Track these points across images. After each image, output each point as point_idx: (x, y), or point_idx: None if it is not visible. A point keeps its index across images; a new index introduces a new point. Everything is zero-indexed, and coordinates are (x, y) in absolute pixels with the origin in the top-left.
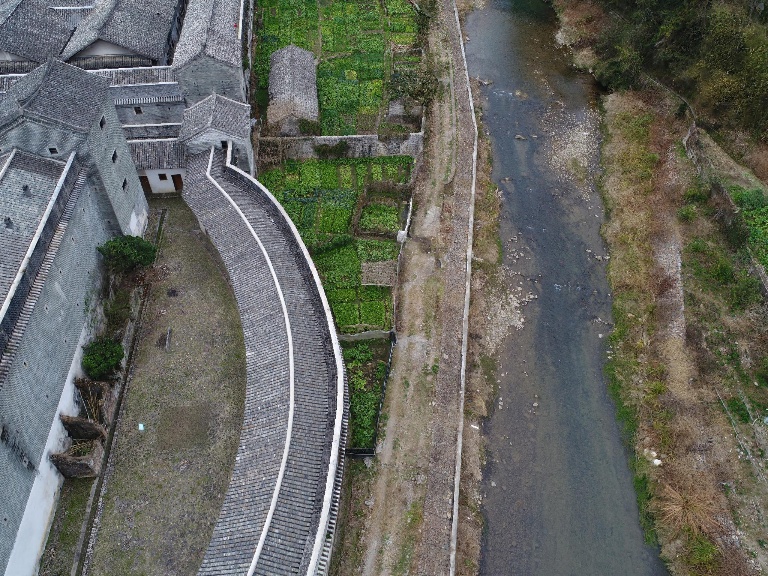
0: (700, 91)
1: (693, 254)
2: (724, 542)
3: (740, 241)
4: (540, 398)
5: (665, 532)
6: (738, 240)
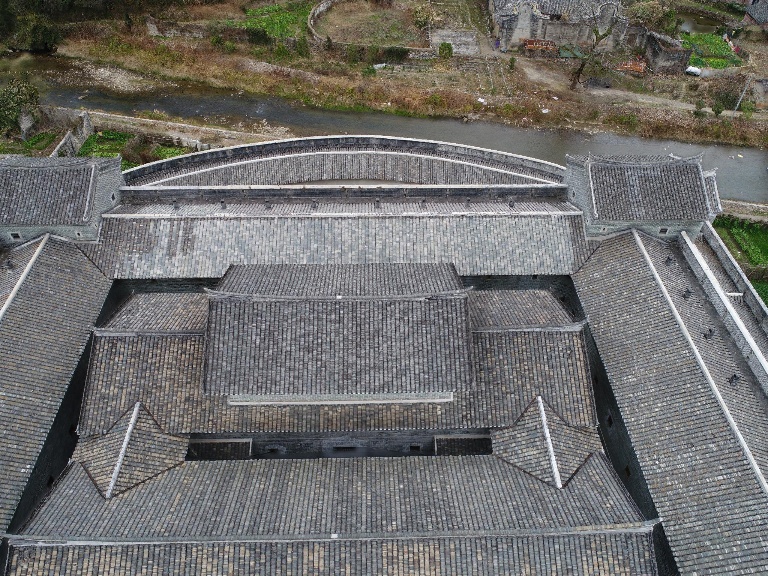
0: (110, 8)
1: (263, 56)
2: (431, 94)
3: (264, 38)
4: (342, 131)
5: (423, 111)
6: (262, 39)
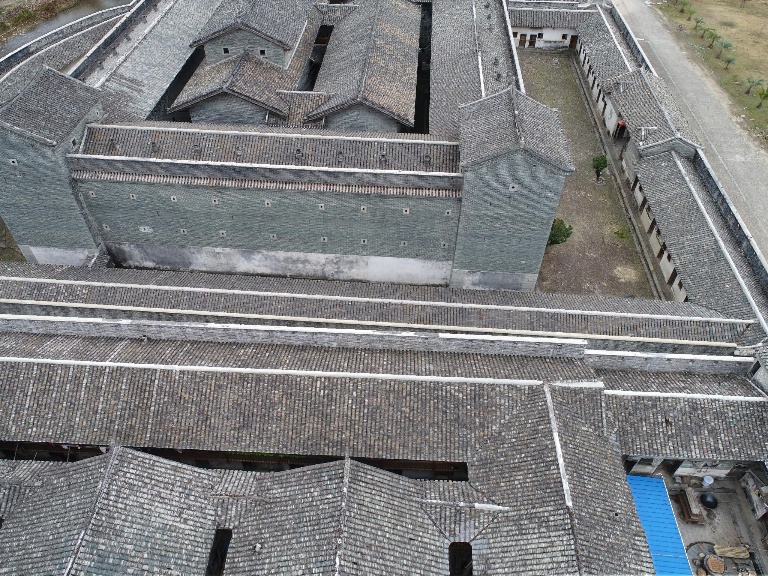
0: None
1: None
2: None
3: None
4: None
5: None
6: None
